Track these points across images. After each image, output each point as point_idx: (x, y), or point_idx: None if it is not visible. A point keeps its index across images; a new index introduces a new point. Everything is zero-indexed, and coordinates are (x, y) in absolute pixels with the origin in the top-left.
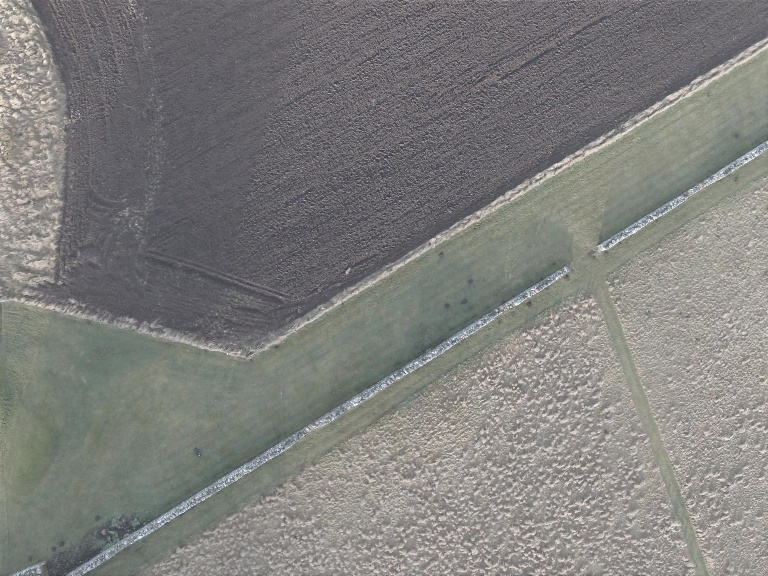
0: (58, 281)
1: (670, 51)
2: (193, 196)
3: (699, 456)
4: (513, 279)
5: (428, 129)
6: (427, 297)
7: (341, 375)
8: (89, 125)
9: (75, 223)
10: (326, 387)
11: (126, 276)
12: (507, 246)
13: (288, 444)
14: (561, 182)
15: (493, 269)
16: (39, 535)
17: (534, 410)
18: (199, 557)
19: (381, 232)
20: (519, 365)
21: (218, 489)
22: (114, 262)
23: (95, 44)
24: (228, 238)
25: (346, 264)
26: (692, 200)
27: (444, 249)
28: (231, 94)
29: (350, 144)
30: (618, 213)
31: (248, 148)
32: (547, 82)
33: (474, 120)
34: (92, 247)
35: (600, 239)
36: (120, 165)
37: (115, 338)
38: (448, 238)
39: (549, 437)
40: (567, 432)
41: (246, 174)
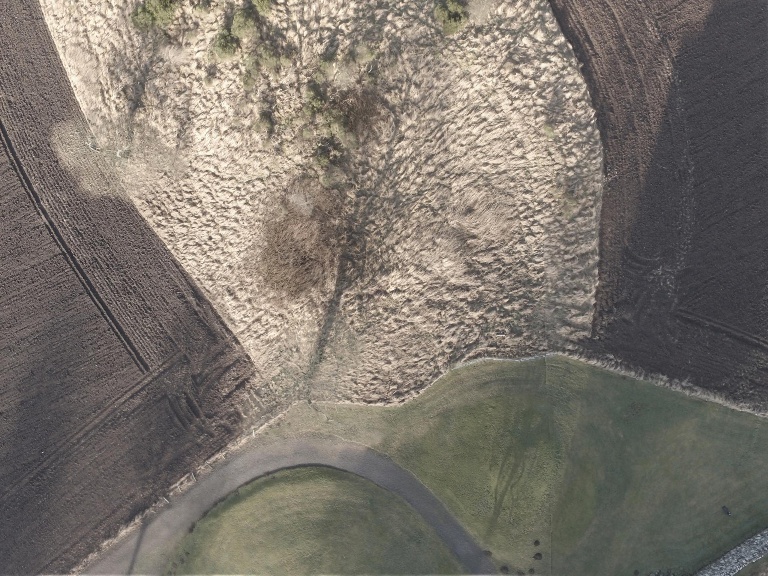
0: (595, 336)
1: None
2: (720, 257)
3: None
4: None
5: None
6: None
7: None
8: (625, 184)
9: (612, 279)
10: None
11: (659, 333)
12: None
13: None
14: None
15: None
16: None
17: None
18: None
19: None
20: None
21: None
22: (647, 319)
23: (632, 105)
24: (754, 300)
25: None
26: None
27: None
28: (757, 158)
29: None
30: None
31: None
32: None
33: None
34: (627, 304)
35: None
36: (654, 224)
37: (649, 394)
38: None
39: None
40: None
41: None
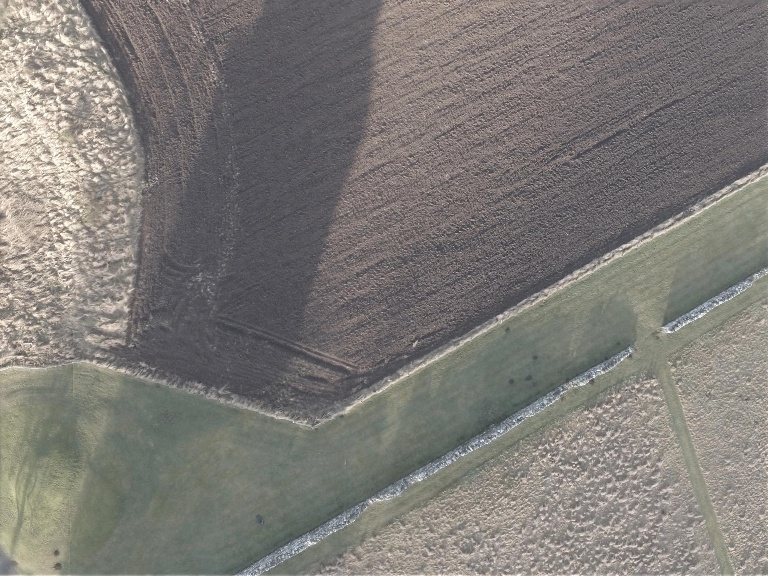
0: (129, 344)
1: (740, 136)
2: (265, 263)
3: (754, 539)
4: (577, 357)
5: (499, 205)
6: (492, 372)
7: (405, 447)
8: (166, 190)
9: (148, 287)
10: (389, 459)
11: (196, 341)
12: (572, 324)
13: (353, 517)
14: (628, 262)
15: (558, 346)
16: None
17: (593, 488)
18: None
19: (449, 306)
20: (580, 443)
21: (282, 560)
22: (185, 326)
23: (175, 110)
24: (298, 307)
25: (413, 337)
26: (755, 283)
27: (510, 325)
28: (306, 163)
29: (422, 217)
30: (683, 295)
31: (321, 218)
32: (618, 163)
33: (545, 198)
34: (164, 311)
35: (665, 320)
36: (195, 230)
37: (183, 402)
38: (515, 314)
39: (607, 516)
40: (625, 511)
41: (318, 243)
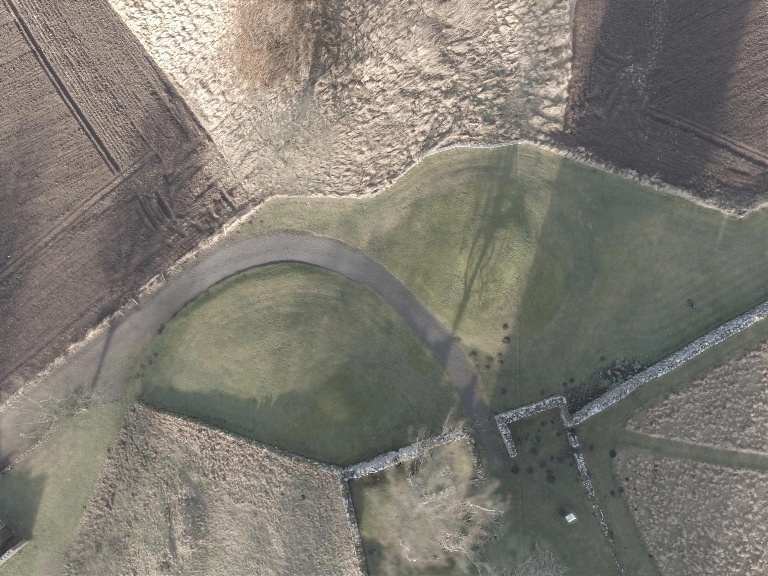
0: (567, 129)
1: None
2: (691, 59)
3: None
4: None
5: None
6: None
7: None
8: None
9: (585, 74)
10: None
11: (629, 129)
12: None
13: None
14: None
15: None
16: (551, 370)
17: None
18: (689, 404)
19: None
20: None
21: (730, 334)
22: (618, 115)
23: None
24: (722, 101)
25: None
26: None
27: None
28: None
29: None
30: None
31: (742, 17)
32: None
33: None
34: (599, 99)
35: None
36: (627, 23)
37: (618, 188)
38: None
39: None
40: None
41: (740, 42)
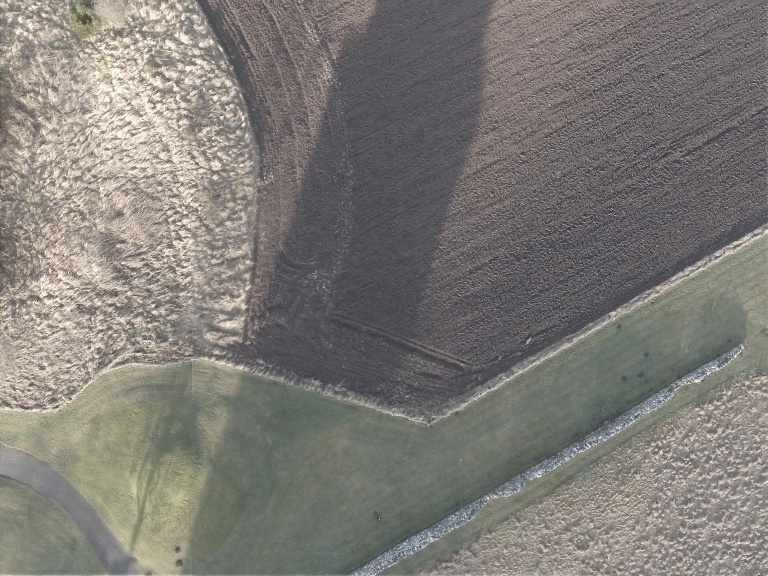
0: (246, 341)
1: None
2: (379, 261)
3: None
4: (689, 354)
5: (611, 203)
6: (605, 369)
7: (520, 444)
8: (281, 187)
9: (265, 284)
10: (505, 456)
11: (313, 338)
12: (683, 321)
13: (474, 514)
14: (738, 259)
15: (669, 343)
16: None
17: (705, 485)
18: None
19: (562, 303)
20: (691, 439)
21: (404, 556)
22: (301, 324)
23: (290, 108)
24: (412, 304)
25: (527, 334)
26: None
27: (622, 322)
28: (419, 161)
29: (534, 215)
30: None
31: (434, 215)
32: (728, 160)
33: (656, 195)
34: (280, 308)
35: None
36: (310, 228)
37: (300, 399)
38: (627, 311)
39: (719, 512)
40: (737, 508)
41: (431, 241)
